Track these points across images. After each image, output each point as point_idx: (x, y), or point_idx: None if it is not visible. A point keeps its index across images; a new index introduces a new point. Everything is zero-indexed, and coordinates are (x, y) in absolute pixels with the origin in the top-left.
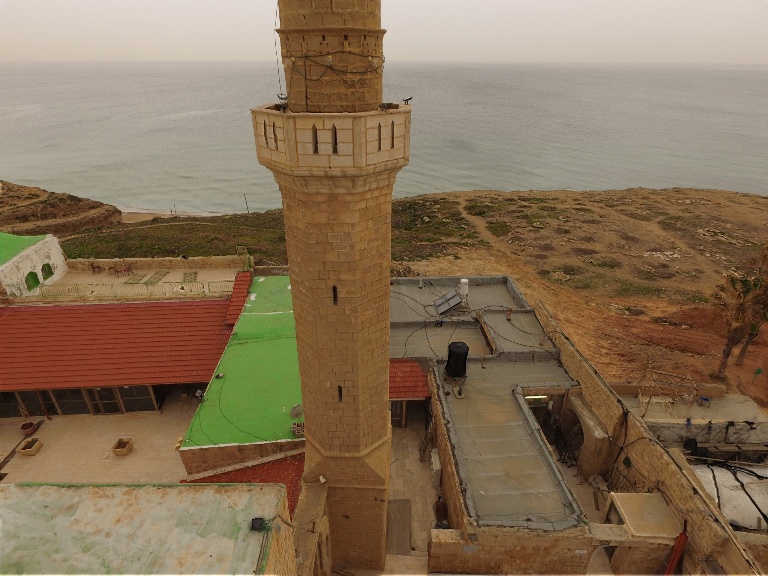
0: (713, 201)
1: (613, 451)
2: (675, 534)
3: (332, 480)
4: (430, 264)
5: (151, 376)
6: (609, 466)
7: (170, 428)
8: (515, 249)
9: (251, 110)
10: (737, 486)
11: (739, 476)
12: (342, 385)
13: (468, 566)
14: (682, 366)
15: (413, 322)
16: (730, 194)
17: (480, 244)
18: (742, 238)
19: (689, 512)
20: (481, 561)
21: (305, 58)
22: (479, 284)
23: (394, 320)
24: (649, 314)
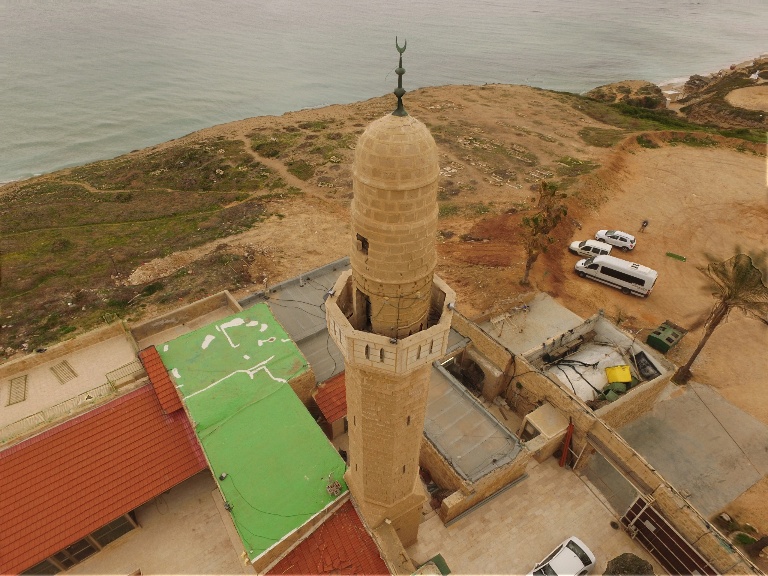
0: (455, 102)
1: (506, 379)
2: (566, 426)
3: (392, 517)
4: (260, 232)
5: (122, 504)
6: (504, 388)
7: (165, 536)
8: (328, 192)
9: (348, 337)
10: (579, 377)
11: (577, 369)
12: (406, 464)
13: (467, 506)
14: (501, 281)
15: (323, 329)
16: (461, 89)
17: (292, 193)
18: (489, 142)
19: (571, 411)
20: (474, 499)
21: (400, 298)
22: (347, 264)
23: (307, 334)
24: (457, 234)
